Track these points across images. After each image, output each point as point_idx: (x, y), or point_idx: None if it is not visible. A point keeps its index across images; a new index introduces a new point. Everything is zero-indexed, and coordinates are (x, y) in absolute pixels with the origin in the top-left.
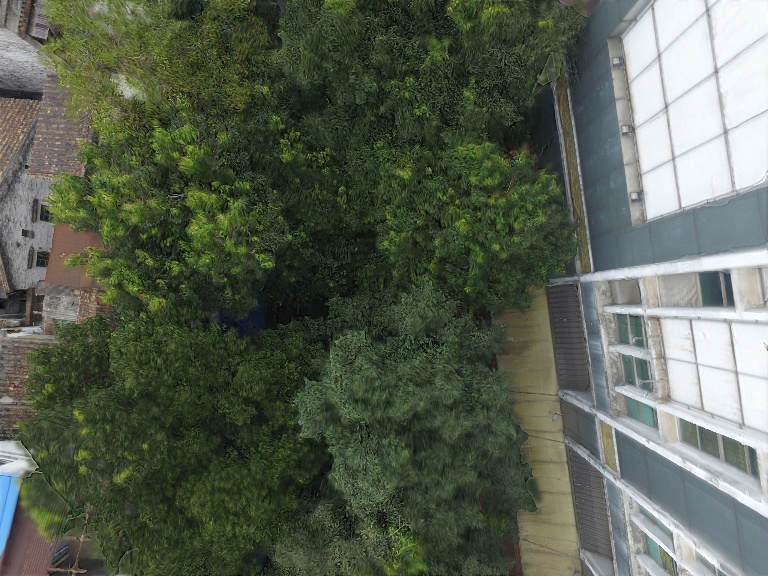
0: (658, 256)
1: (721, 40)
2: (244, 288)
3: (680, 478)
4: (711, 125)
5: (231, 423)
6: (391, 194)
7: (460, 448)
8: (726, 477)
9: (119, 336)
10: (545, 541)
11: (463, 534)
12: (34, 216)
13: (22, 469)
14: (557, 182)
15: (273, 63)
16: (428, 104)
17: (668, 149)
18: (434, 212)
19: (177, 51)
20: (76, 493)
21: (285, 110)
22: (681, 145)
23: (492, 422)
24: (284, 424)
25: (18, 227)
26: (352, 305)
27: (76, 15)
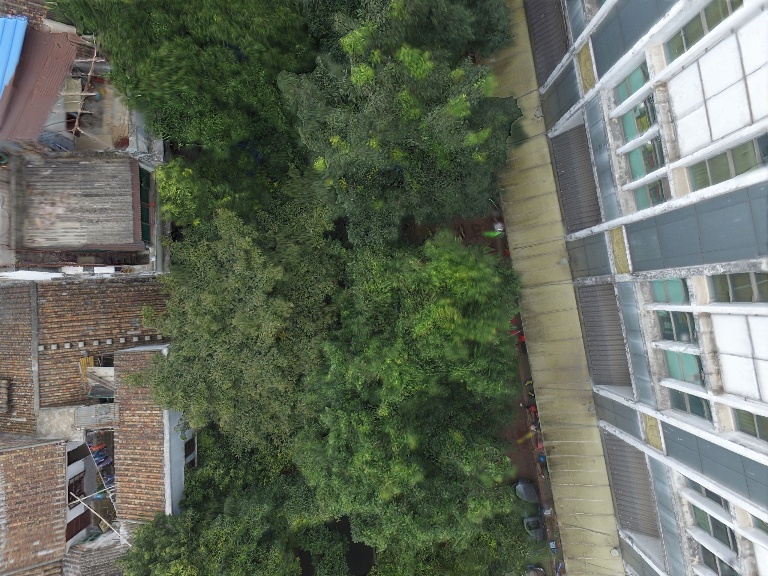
0: None
1: None
2: None
3: None
4: None
5: None
6: None
7: None
8: None
9: None
10: None
11: (453, 47)
12: None
13: None
14: None
15: None
16: None
17: None
18: None
19: None
20: None
21: None
22: None
23: None
24: None
25: None
26: None
27: None
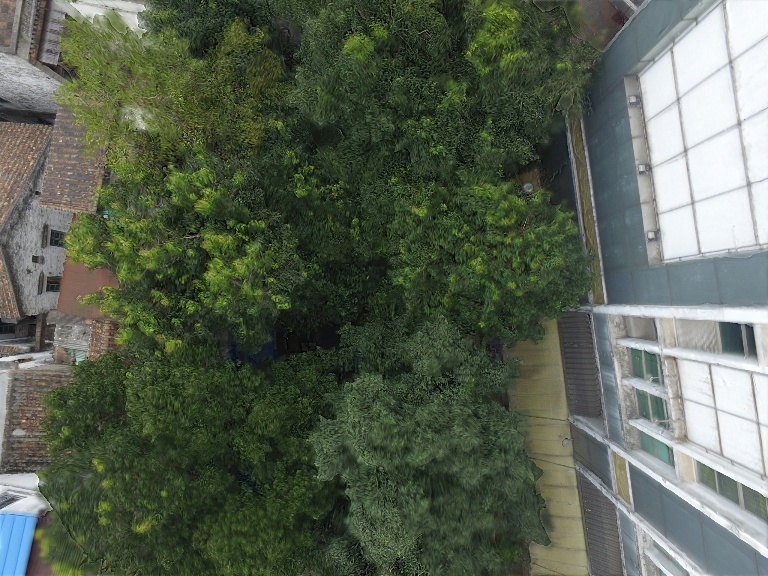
0: (676, 299)
1: (745, 93)
2: (258, 324)
3: (698, 521)
4: (733, 176)
5: (246, 460)
6: (405, 229)
7: (477, 490)
8: (747, 527)
9: (135, 378)
10: (555, 565)
11: (480, 575)
12: (44, 242)
13: (36, 506)
14: (569, 210)
15: (289, 103)
16: (444, 143)
17: (687, 193)
18: (449, 247)
19: (192, 87)
20: (95, 544)
21: (299, 143)
22: (701, 191)
23: (510, 465)
24: (298, 459)
25: (28, 254)
26: (364, 335)
27: (93, 57)
